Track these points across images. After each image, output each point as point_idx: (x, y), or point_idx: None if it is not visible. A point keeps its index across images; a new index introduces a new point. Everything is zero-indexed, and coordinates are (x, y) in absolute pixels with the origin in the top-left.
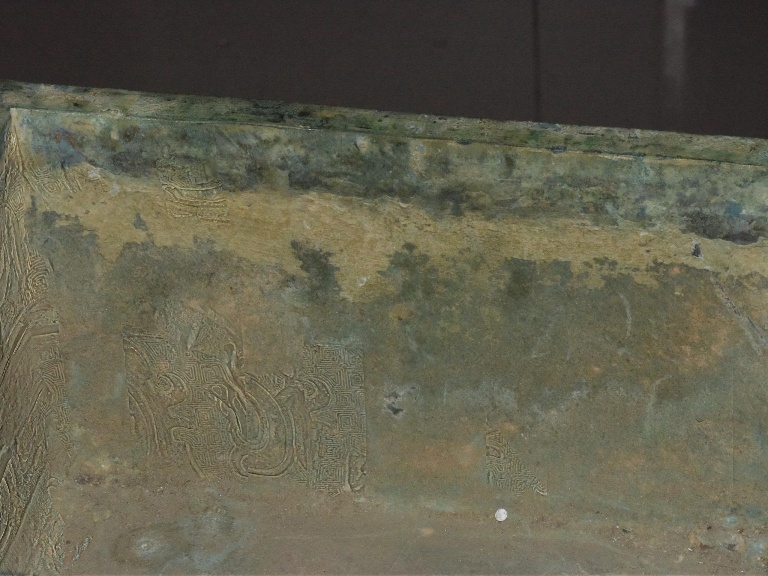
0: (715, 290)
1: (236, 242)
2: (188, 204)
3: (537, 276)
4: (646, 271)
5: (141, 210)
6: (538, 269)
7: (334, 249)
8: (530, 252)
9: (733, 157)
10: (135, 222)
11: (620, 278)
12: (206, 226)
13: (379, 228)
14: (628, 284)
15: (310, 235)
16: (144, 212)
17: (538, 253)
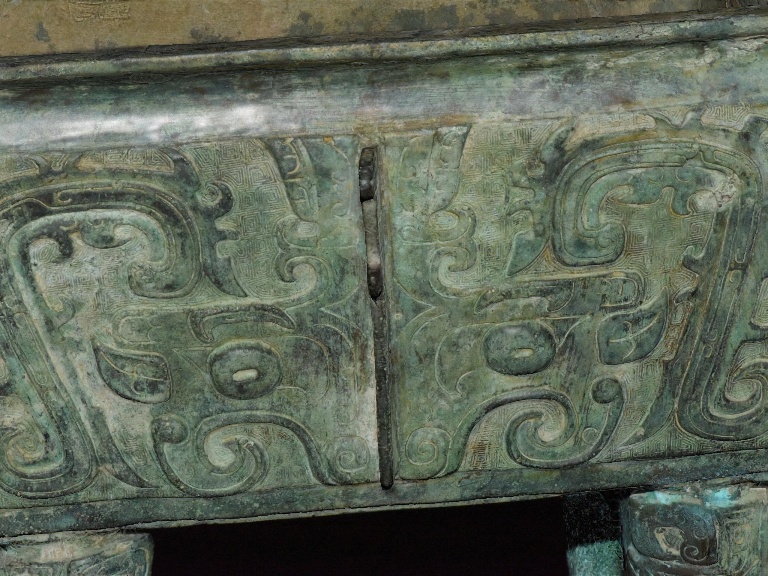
0: (589, 11)
1: (137, 41)
2: (91, 3)
3: (426, 26)
4: (526, 2)
5: (44, 18)
6: (426, 18)
7: (232, 32)
8: (419, 0)
9: None
10: (38, 33)
11: (503, 14)
12: (108, 27)
13: (275, 0)
14: (510, 19)
15: (209, 20)
16: (47, 20)
17: (426, 0)
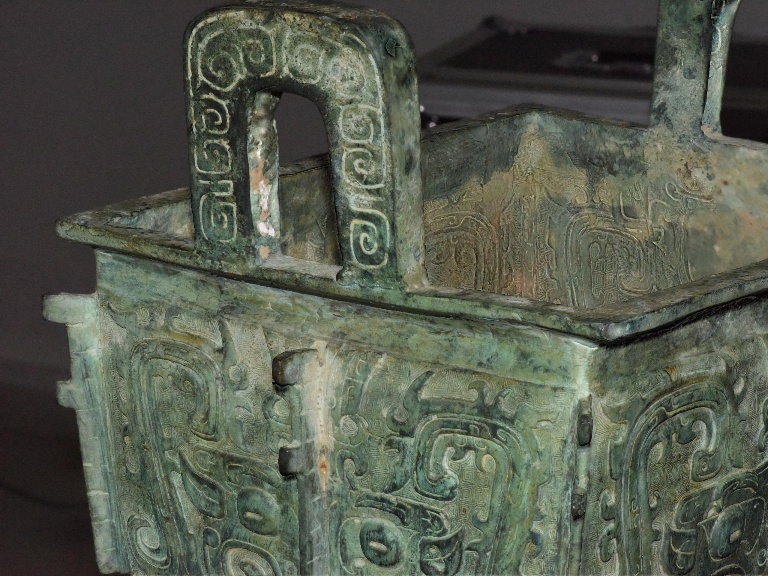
0: None
1: None
2: None
3: None
4: None
5: None
6: None
7: None
8: None
9: (650, 295)
10: None
11: None
12: None
13: None
14: None
15: None
16: None
17: None
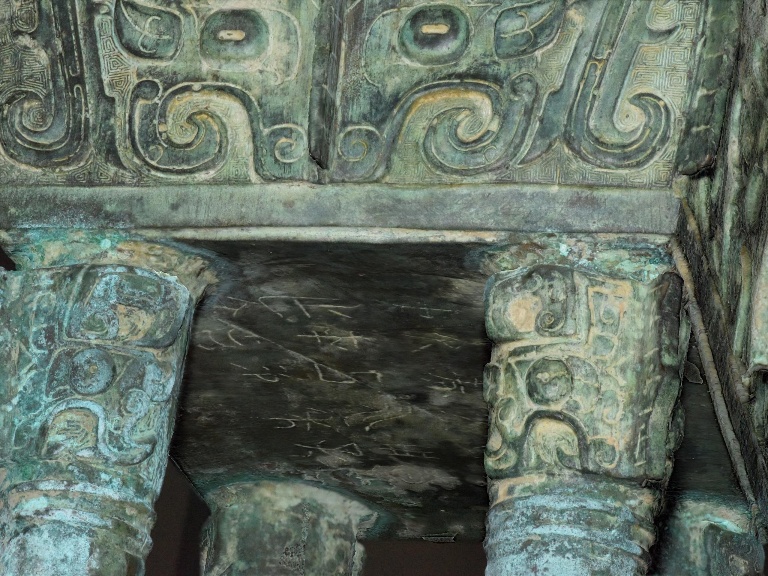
0: None
1: None
2: None
3: None
4: None
5: None
6: None
7: None
8: None
9: None
10: None
11: None
12: None
13: None
14: None
15: None
16: None
17: None
